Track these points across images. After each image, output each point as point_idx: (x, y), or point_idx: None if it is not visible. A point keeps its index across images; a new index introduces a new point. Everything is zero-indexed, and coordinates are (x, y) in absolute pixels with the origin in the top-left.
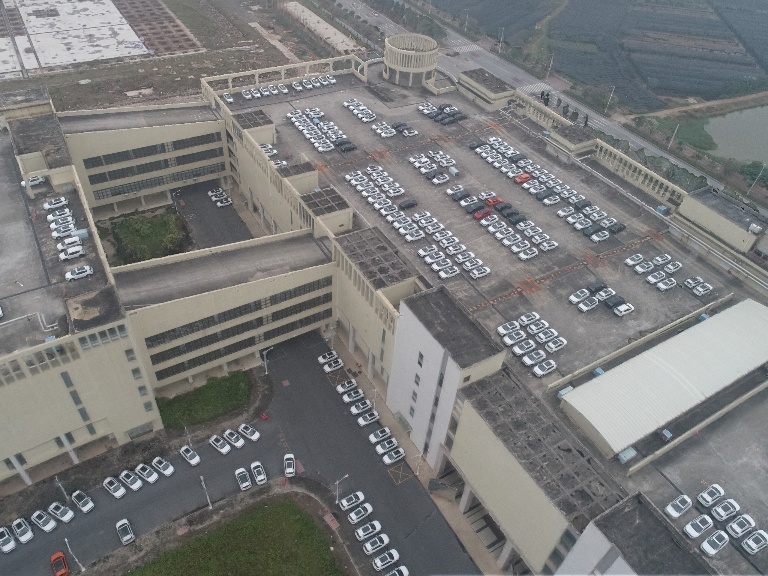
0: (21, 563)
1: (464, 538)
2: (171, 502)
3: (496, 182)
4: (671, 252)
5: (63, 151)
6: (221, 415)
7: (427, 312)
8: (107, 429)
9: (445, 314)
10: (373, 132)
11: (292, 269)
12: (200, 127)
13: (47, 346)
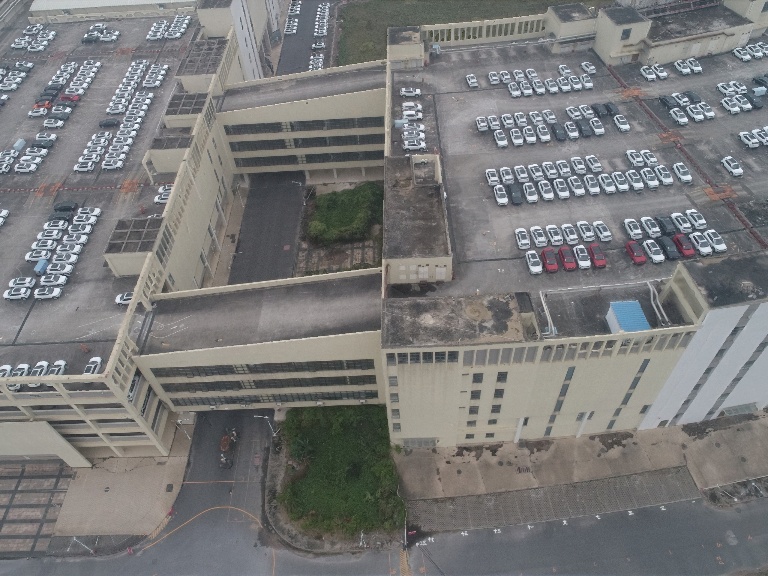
0: None
1: (276, 61)
2: None
3: (3, 129)
4: (1, 51)
5: (391, 181)
6: None
7: (222, 6)
8: None
9: (214, 4)
10: (3, 229)
11: (259, 90)
12: (194, 295)
13: (436, 28)
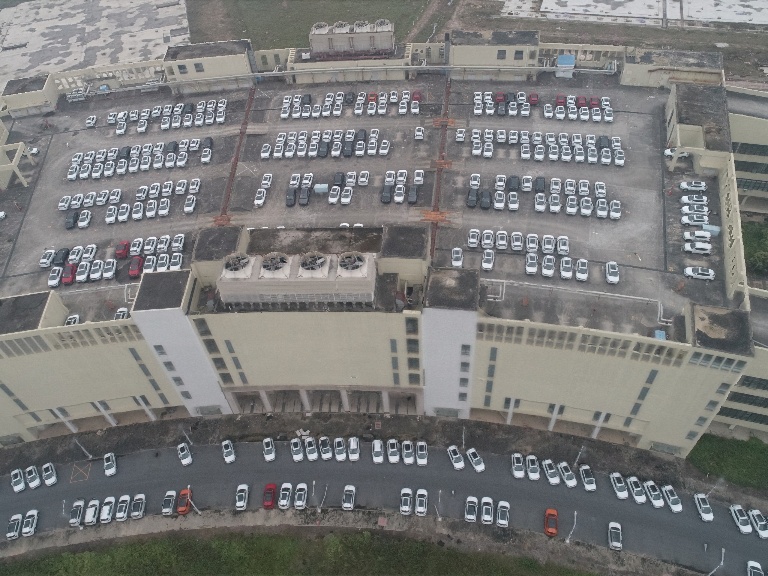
0: (522, 494)
1: None
2: (666, 540)
3: None
4: None
5: (724, 133)
6: (752, 486)
7: None
8: (640, 429)
9: None
10: None
11: None
12: None
13: (664, 344)
